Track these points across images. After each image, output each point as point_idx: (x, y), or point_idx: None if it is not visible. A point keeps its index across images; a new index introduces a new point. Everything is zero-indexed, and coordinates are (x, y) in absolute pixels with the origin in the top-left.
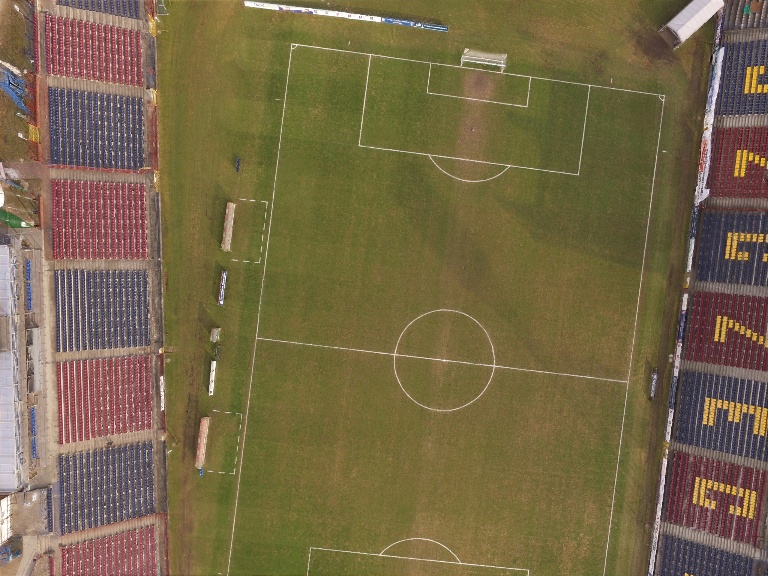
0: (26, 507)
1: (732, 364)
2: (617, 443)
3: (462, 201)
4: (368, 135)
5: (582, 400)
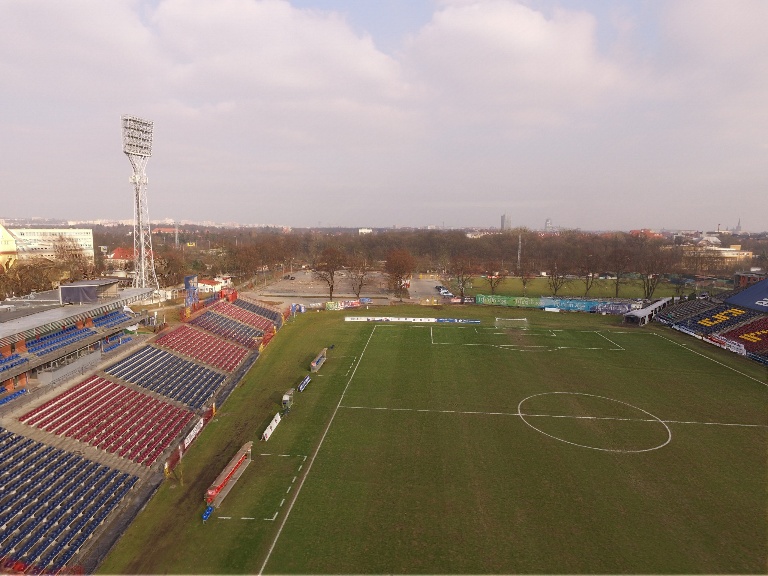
0: None
1: None
2: None
3: None
4: None
5: None
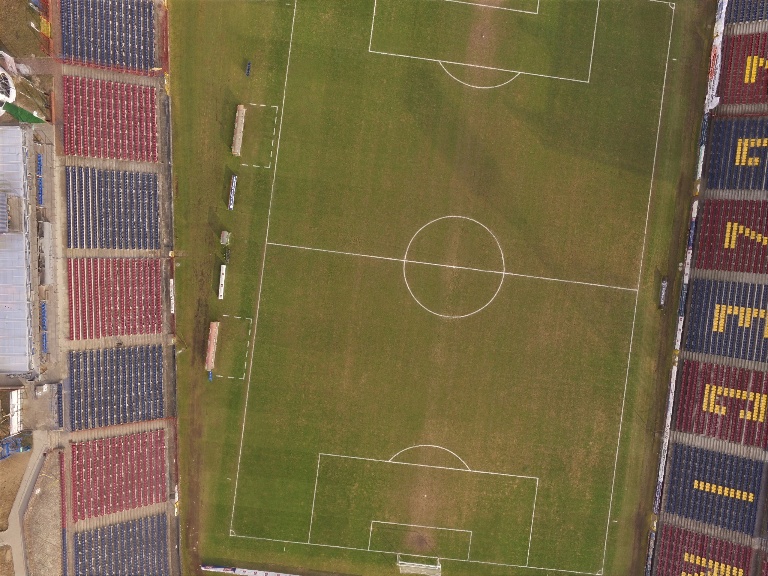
0: (36, 402)
1: (742, 270)
2: (627, 351)
3: (472, 107)
4: (378, 40)
5: (592, 308)
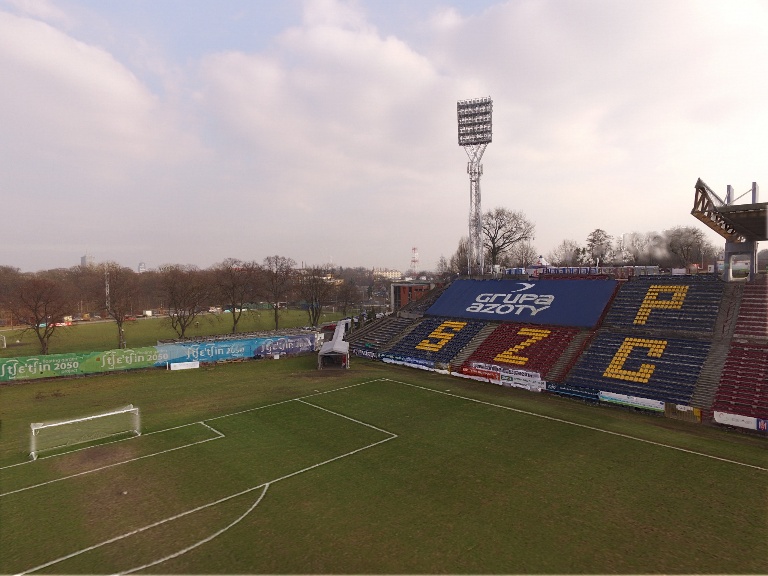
0: None
1: None
2: None
3: None
4: None
5: None
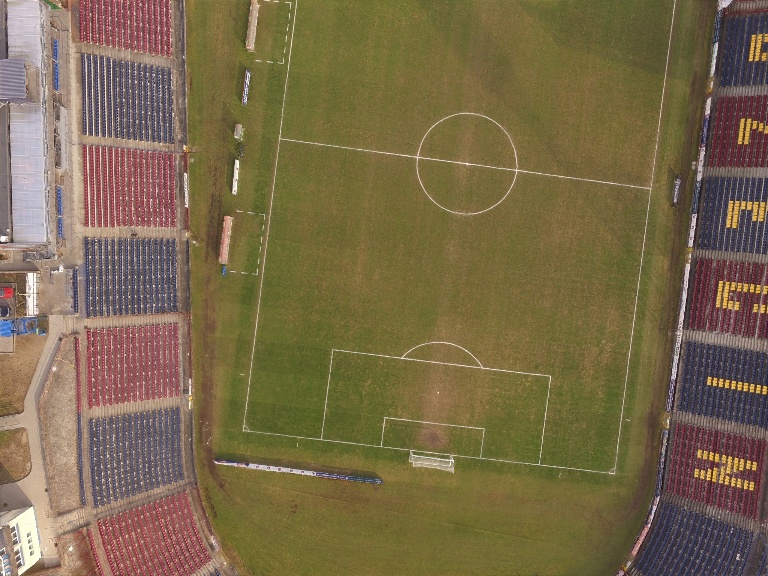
0: (52, 287)
1: (756, 165)
2: (639, 250)
3: (485, 4)
4: None
5: (605, 206)
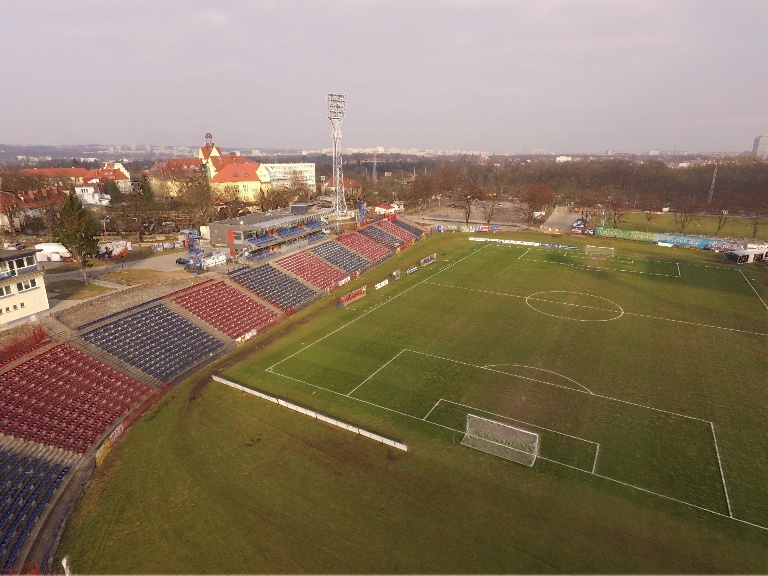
0: None
1: None
2: None
3: None
4: None
5: None
